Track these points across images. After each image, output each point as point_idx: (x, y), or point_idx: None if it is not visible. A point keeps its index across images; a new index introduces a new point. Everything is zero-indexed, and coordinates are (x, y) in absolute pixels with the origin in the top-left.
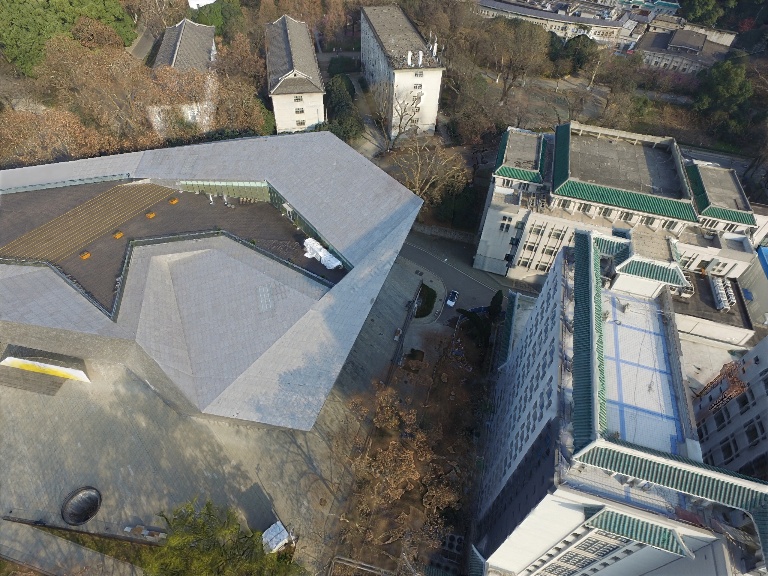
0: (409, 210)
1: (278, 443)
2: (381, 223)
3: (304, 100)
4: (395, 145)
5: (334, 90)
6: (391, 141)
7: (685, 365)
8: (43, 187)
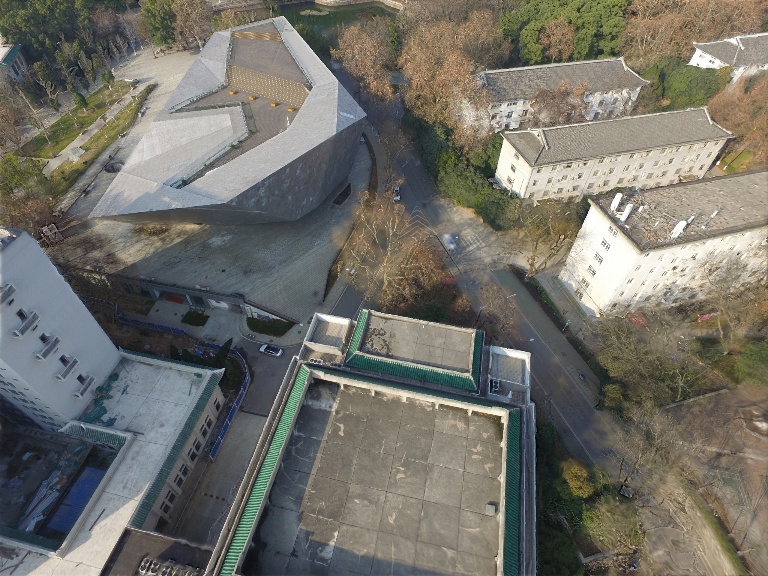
0: (219, 198)
1: (123, 230)
2: (213, 188)
3: (520, 161)
4: (551, 284)
5: (600, 194)
6: (556, 278)
7: (50, 573)
8: (299, 63)
